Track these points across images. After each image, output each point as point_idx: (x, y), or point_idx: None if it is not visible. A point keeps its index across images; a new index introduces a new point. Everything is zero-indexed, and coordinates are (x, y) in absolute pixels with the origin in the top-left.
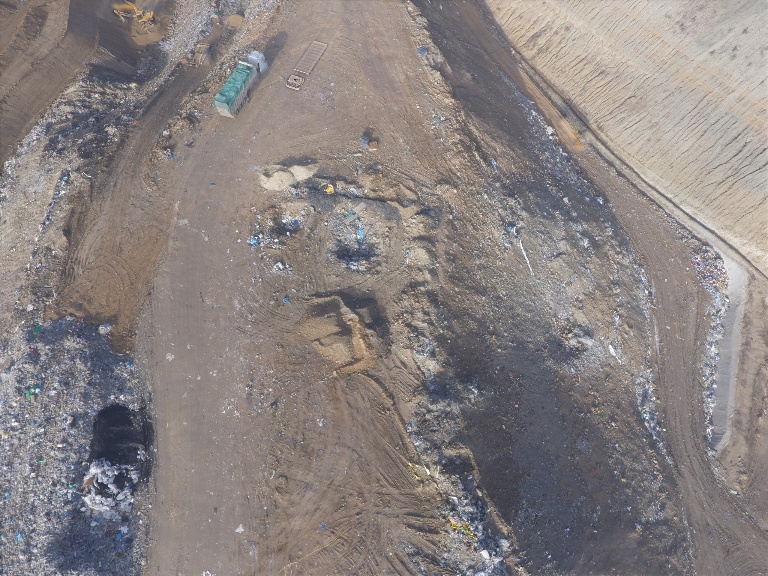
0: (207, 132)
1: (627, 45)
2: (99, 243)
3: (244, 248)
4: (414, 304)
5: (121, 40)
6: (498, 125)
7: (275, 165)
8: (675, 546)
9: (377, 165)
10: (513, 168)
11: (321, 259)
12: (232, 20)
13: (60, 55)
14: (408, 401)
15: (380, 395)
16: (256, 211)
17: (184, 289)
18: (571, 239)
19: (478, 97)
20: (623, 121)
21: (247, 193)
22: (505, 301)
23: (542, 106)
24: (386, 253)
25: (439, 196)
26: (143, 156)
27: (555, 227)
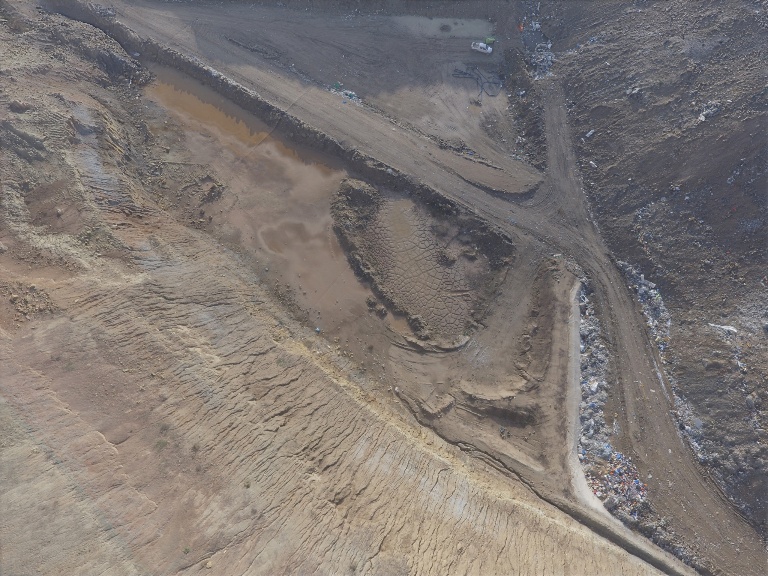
0: None
1: None
2: None
3: None
4: None
5: None
6: None
7: None
8: (618, 197)
9: None
10: None
11: None
12: None
13: None
14: None
15: None
16: None
17: None
18: None
19: None
20: None
21: None
22: None
23: None
24: None
25: None
26: None
27: None
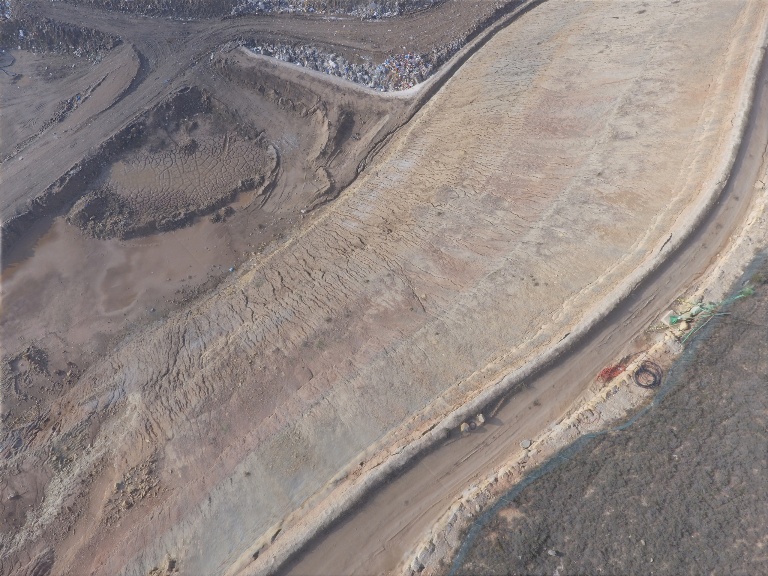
0: None
1: None
2: None
3: None
4: None
5: None
6: None
7: None
8: None
9: None
10: None
11: None
12: None
13: None
14: None
15: None
16: None
17: None
18: None
19: None
20: None
21: None
22: None
23: None
24: None
25: None
26: None
27: None
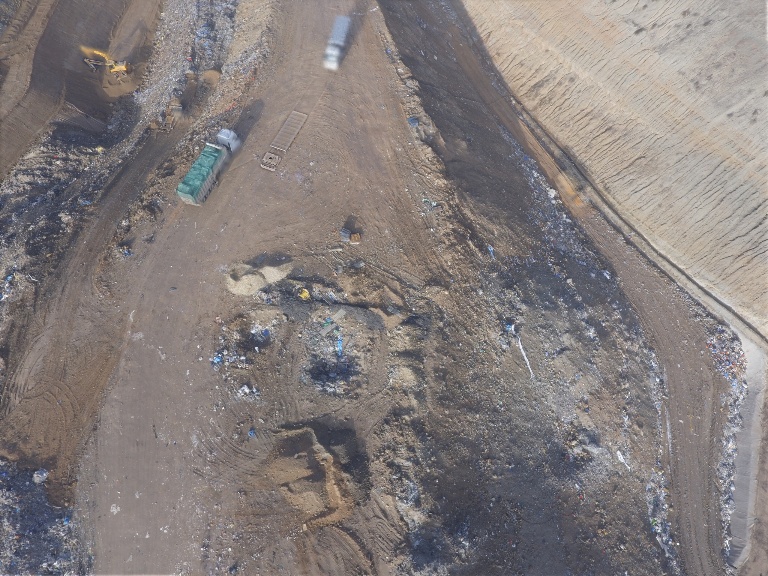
0: (170, 224)
1: (637, 101)
2: (40, 365)
3: (206, 368)
4: (397, 438)
5: (91, 93)
6: (496, 200)
7: (244, 264)
8: None
9: (359, 262)
10: (512, 250)
11: (293, 380)
12: (208, 76)
13: (21, 115)
14: (388, 561)
15: (356, 554)
16: (221, 321)
17: (135, 421)
18: (576, 330)
19: (474, 170)
20: (632, 183)
21: (212, 299)
22: (502, 413)
23: (544, 164)
24: (367, 371)
25: (428, 299)
26: (97, 253)
27: (558, 318)
